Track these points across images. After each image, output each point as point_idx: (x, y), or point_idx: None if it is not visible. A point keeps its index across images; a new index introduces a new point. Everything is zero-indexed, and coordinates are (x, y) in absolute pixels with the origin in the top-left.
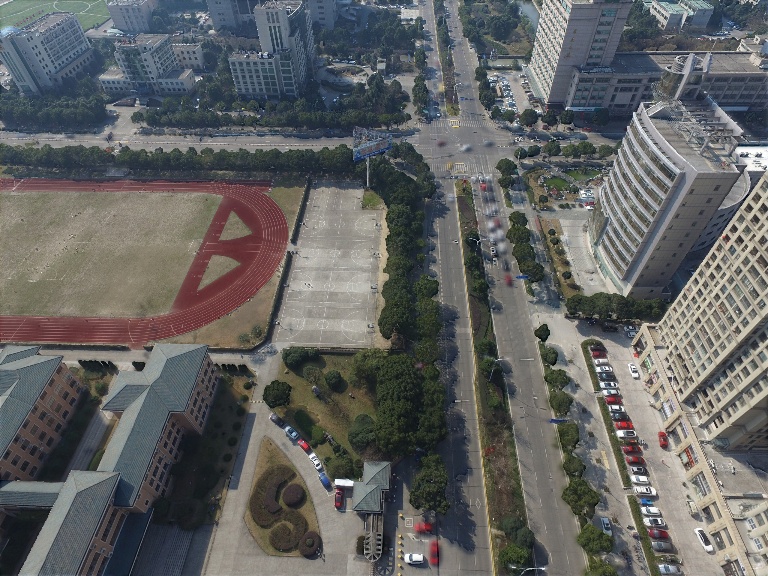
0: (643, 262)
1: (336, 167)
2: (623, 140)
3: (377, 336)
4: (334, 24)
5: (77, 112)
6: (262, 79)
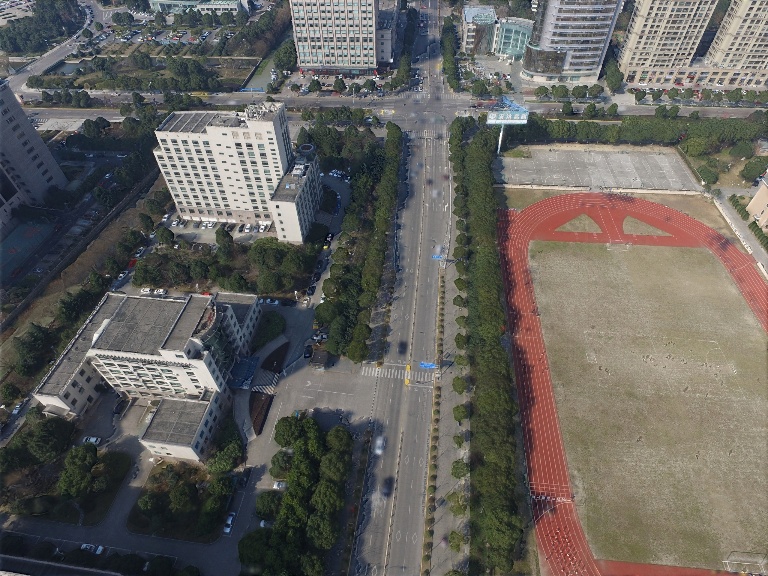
0: (607, 47)
1: None
2: (559, 6)
3: (665, 152)
4: (65, 176)
5: (344, 444)
6: (310, 200)
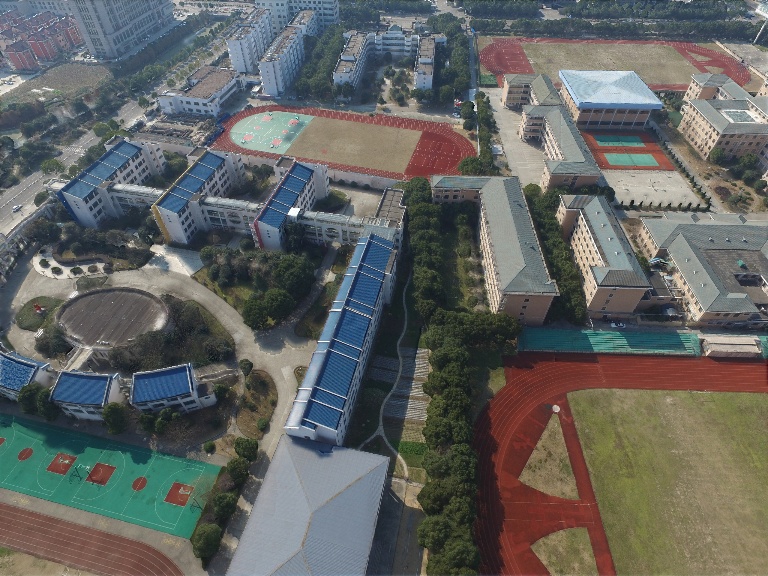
0: None
1: (735, 31)
2: None
3: None
4: None
5: (532, 6)
6: None
